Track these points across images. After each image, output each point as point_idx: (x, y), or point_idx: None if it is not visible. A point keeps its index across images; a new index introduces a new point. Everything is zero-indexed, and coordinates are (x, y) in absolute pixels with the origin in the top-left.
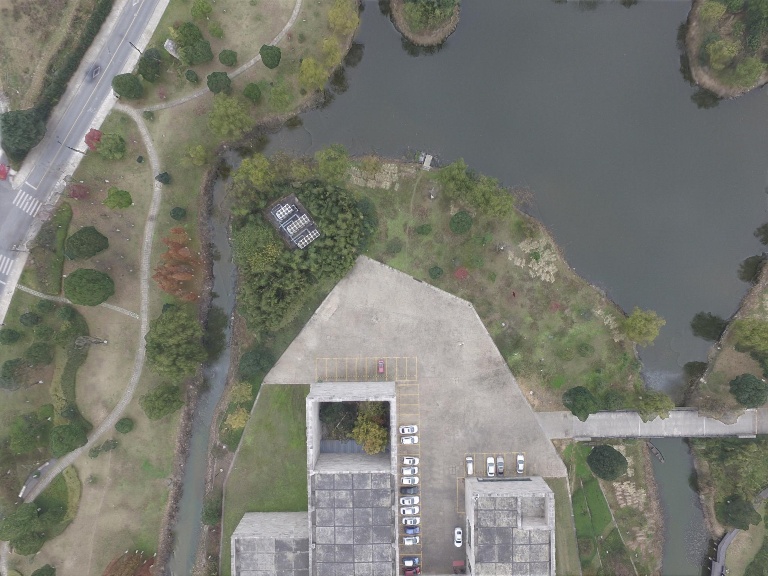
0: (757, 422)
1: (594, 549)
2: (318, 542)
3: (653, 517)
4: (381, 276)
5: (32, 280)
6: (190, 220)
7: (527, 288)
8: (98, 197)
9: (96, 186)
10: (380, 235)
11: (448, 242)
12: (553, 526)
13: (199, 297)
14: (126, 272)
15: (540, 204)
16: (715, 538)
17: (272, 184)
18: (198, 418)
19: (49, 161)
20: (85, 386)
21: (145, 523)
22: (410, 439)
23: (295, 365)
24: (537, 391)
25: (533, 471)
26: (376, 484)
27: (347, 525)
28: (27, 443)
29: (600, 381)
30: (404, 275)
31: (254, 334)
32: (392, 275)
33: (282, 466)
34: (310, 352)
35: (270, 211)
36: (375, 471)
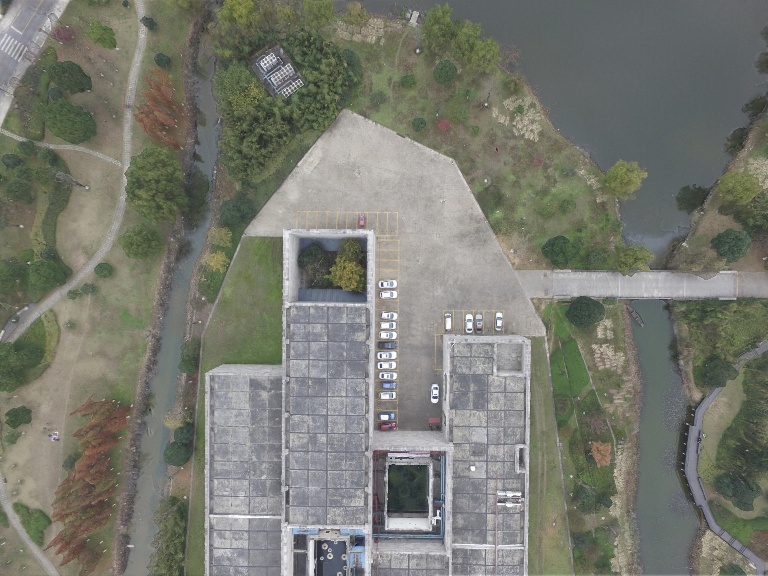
0: (738, 285)
1: (571, 409)
2: (292, 375)
3: (631, 381)
4: (364, 130)
5: (15, 125)
6: (175, 71)
7: (510, 146)
8: (83, 42)
9: (81, 29)
10: (364, 89)
11: (432, 98)
12: (529, 373)
13: (182, 149)
14: (109, 118)
15: (526, 64)
16: (693, 404)
17: (256, 28)
18: (178, 271)
19: (35, 6)
20: (66, 232)
21: (123, 373)
22: (389, 293)
23: (276, 218)
24: (518, 249)
25: (512, 330)
26: (351, 318)
27: (321, 359)
28: (6, 280)
29: (581, 238)
30: (387, 130)
31: (236, 187)
32: (375, 130)
33: (260, 319)
34: (291, 205)
35: (255, 62)
36: (350, 304)
